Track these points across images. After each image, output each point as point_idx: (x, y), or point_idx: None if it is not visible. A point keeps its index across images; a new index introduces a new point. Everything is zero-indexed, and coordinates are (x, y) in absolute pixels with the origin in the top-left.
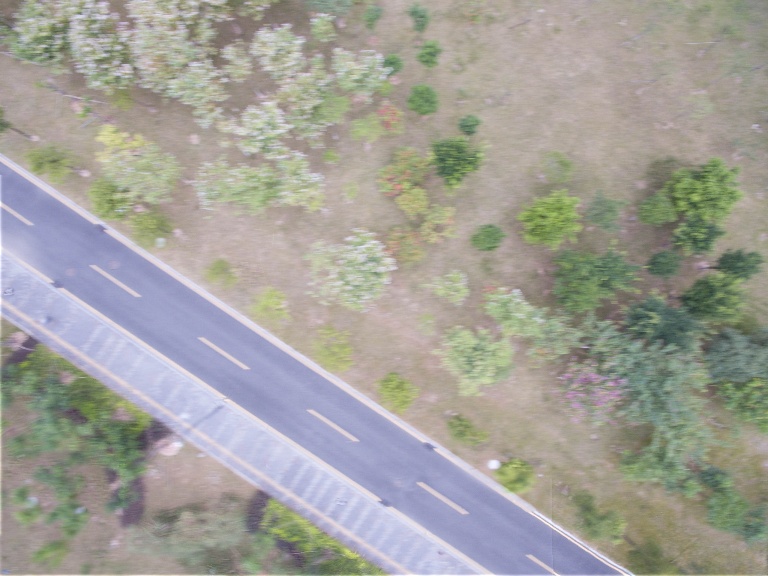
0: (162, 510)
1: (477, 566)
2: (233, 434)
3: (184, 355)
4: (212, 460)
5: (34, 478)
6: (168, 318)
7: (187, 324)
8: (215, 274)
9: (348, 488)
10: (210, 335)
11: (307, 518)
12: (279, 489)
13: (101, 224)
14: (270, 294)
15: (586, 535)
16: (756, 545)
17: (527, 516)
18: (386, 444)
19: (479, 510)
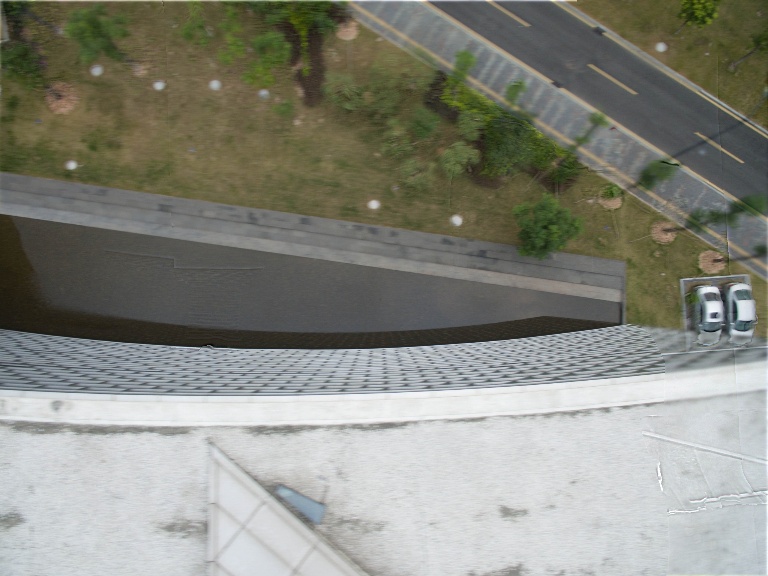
0: (346, 84)
1: (647, 144)
2: (410, 19)
3: None
4: (390, 44)
5: (218, 62)
6: None
7: None
8: None
9: (522, 70)
10: None
11: (484, 95)
12: (456, 70)
13: None
14: None
15: (752, 111)
16: None
17: (694, 96)
18: (557, 29)
19: (648, 91)
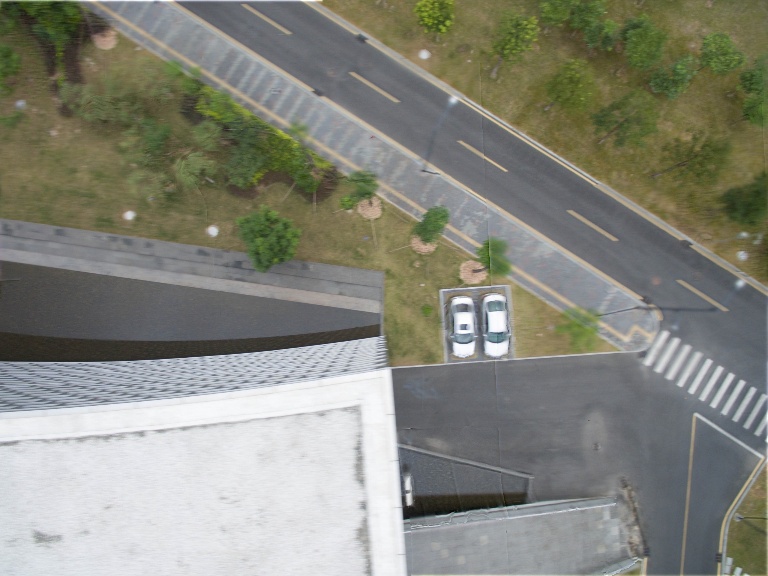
0: (99, 94)
1: (409, 152)
2: (169, 28)
3: None
4: (149, 53)
5: None
6: None
7: None
8: None
9: (282, 78)
10: None
11: (241, 104)
12: (214, 79)
13: None
14: None
15: (515, 119)
16: (682, 125)
17: (457, 104)
18: (319, 36)
19: (410, 98)
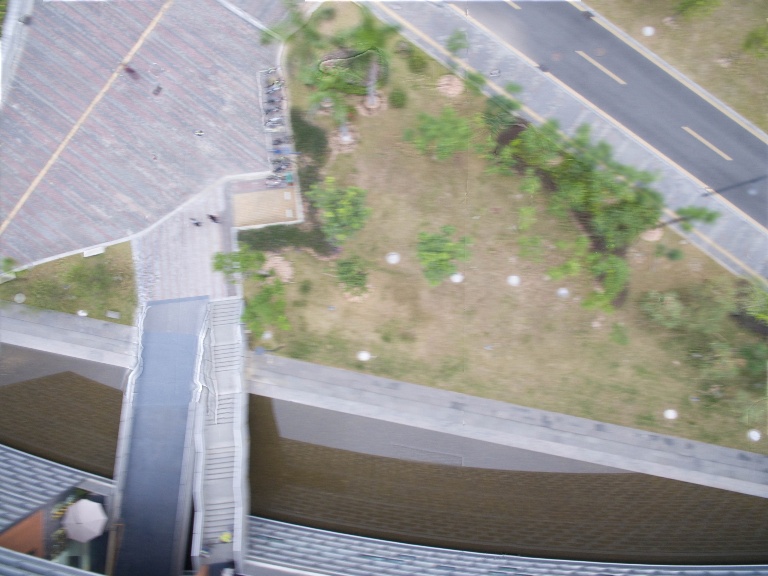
0: (652, 291)
1: None
2: (715, 223)
3: (667, 143)
4: (693, 248)
5: (517, 257)
6: (653, 106)
7: (671, 113)
8: (703, 64)
9: None
10: (694, 125)
11: None
12: (760, 279)
13: (589, 11)
14: (760, 85)
15: None
16: None
17: None
18: None
19: None
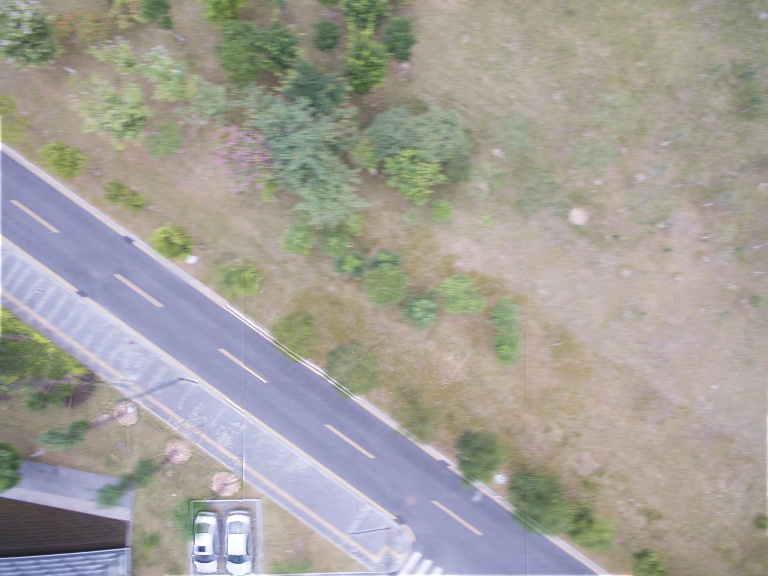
0: None
1: (169, 358)
2: None
3: None
4: None
5: None
6: None
7: None
8: None
9: (46, 278)
10: None
11: (2, 304)
12: None
13: None
14: None
15: (277, 330)
16: (444, 344)
17: (221, 311)
18: (86, 236)
19: (174, 303)
